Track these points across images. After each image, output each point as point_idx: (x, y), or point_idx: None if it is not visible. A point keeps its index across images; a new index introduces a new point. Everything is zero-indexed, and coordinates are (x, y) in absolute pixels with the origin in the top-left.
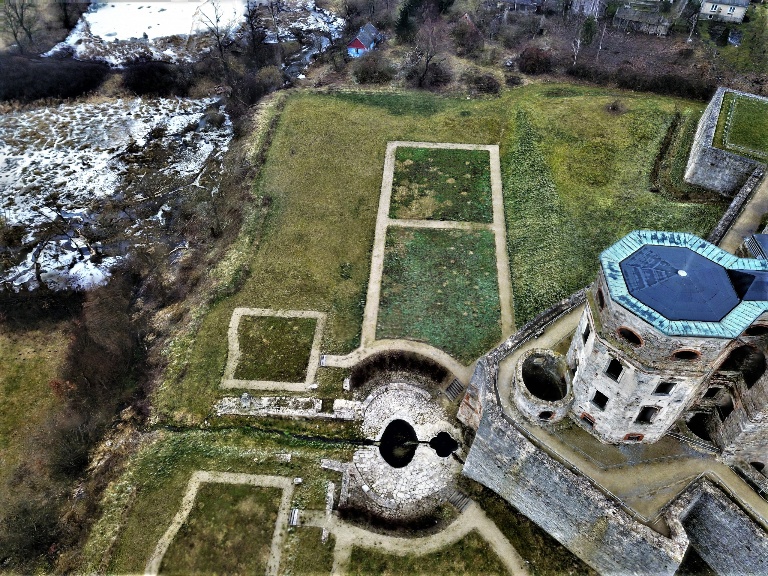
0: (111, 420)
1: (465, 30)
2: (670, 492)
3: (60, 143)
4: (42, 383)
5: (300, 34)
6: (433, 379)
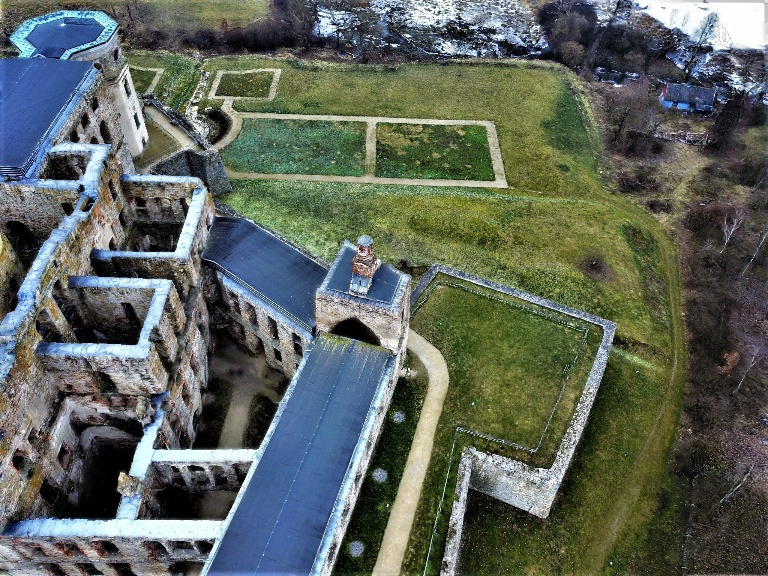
0: (212, 51)
1: (753, 158)
2: None
3: (462, 1)
4: None
5: (711, 79)
6: None
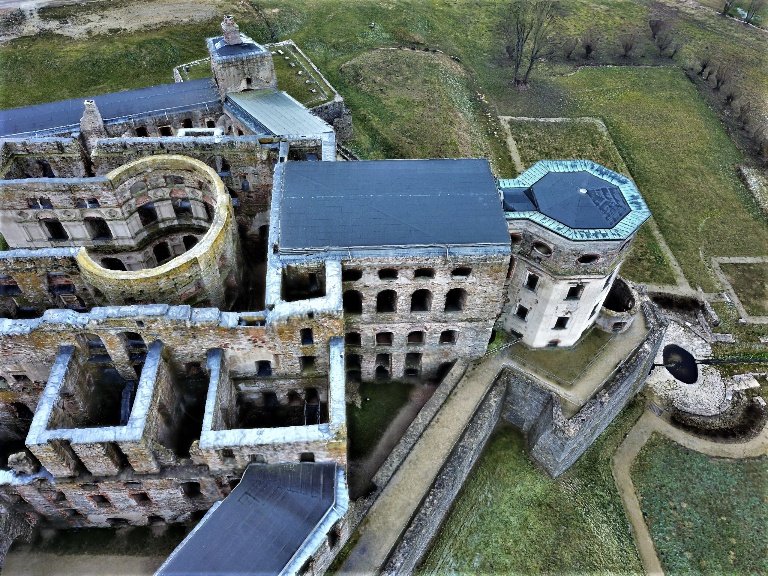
0: None
1: None
2: None
3: None
4: None
5: None
6: None
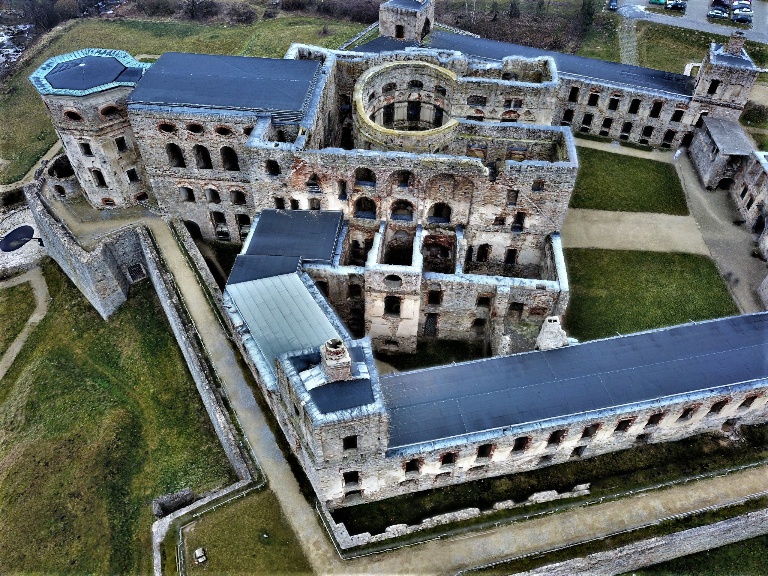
0: None
1: None
2: None
3: None
4: None
5: None
6: None
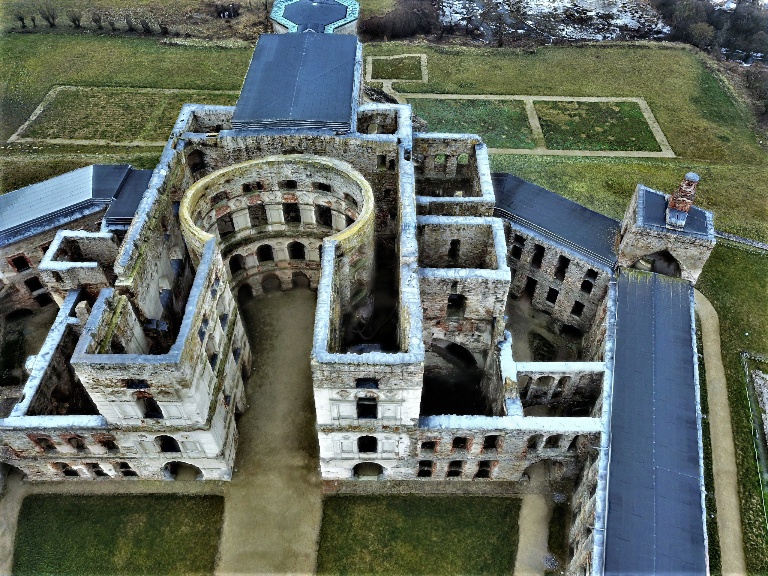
0: None
1: None
2: None
3: None
4: (369, 17)
5: None
6: None
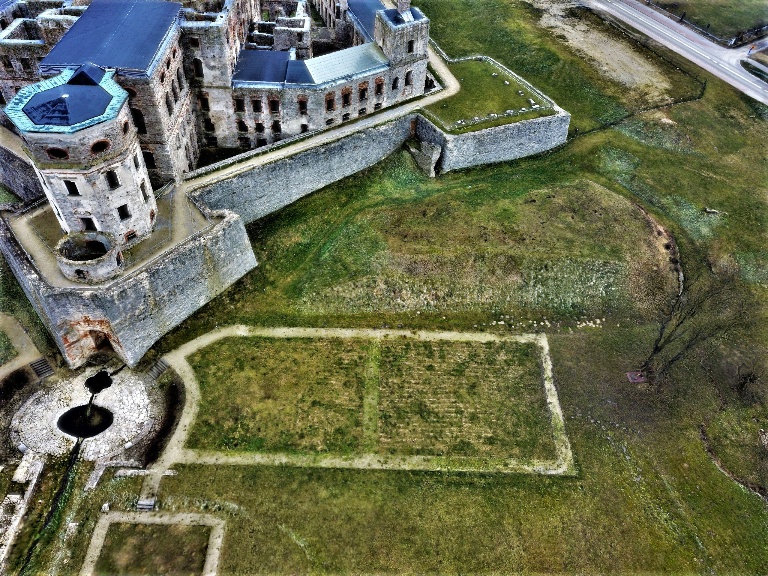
0: None
1: None
2: (195, 212)
3: None
4: None
5: None
6: (20, 388)
